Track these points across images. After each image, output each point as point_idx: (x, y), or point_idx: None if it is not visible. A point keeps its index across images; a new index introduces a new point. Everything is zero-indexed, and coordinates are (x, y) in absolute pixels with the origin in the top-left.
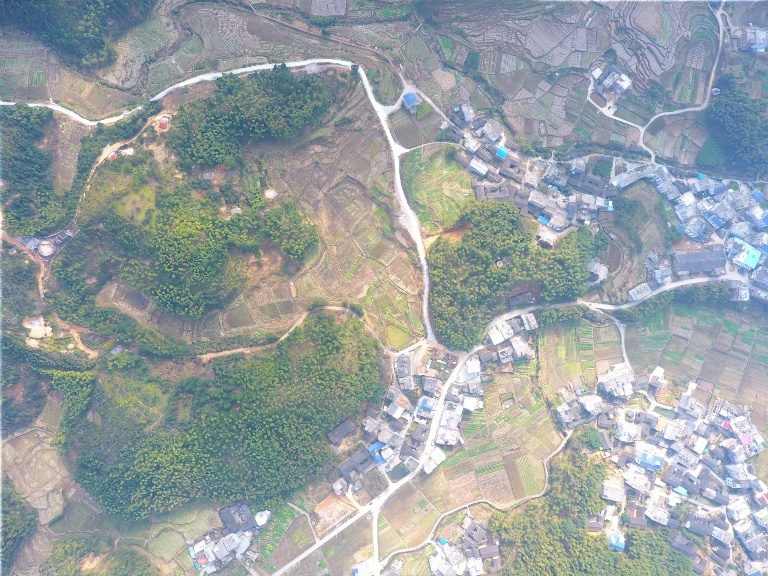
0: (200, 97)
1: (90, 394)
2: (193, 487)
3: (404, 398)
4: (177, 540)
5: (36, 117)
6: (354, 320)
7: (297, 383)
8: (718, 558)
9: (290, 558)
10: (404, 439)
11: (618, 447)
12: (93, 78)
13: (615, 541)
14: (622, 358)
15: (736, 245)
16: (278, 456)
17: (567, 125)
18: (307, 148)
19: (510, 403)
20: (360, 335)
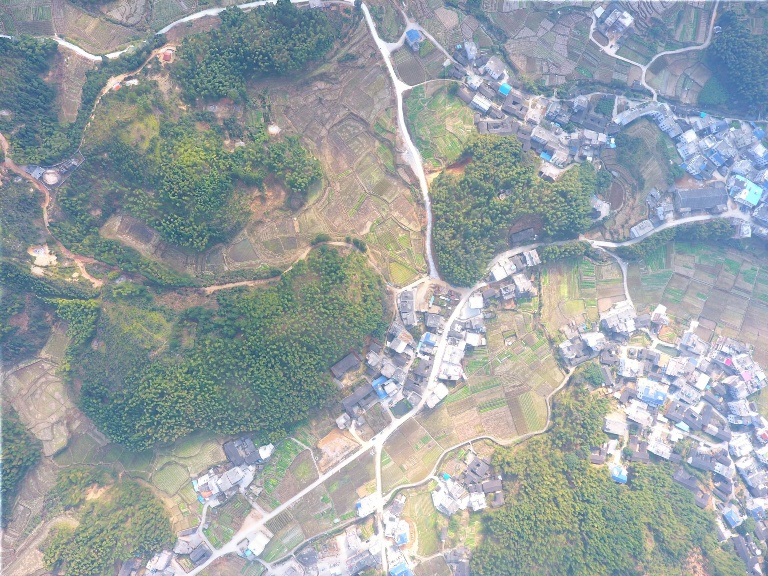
0: (204, 30)
1: (95, 322)
2: (197, 416)
3: (407, 333)
4: (181, 473)
5: (41, 48)
6: (357, 254)
7: (301, 311)
8: (720, 493)
9: (293, 493)
10: (407, 375)
11: (620, 383)
12: (97, 14)
13: (617, 473)
14: (624, 296)
15: (738, 182)
16: (282, 386)
17: (569, 64)
18: (310, 84)
19: (513, 340)
20: (363, 268)
